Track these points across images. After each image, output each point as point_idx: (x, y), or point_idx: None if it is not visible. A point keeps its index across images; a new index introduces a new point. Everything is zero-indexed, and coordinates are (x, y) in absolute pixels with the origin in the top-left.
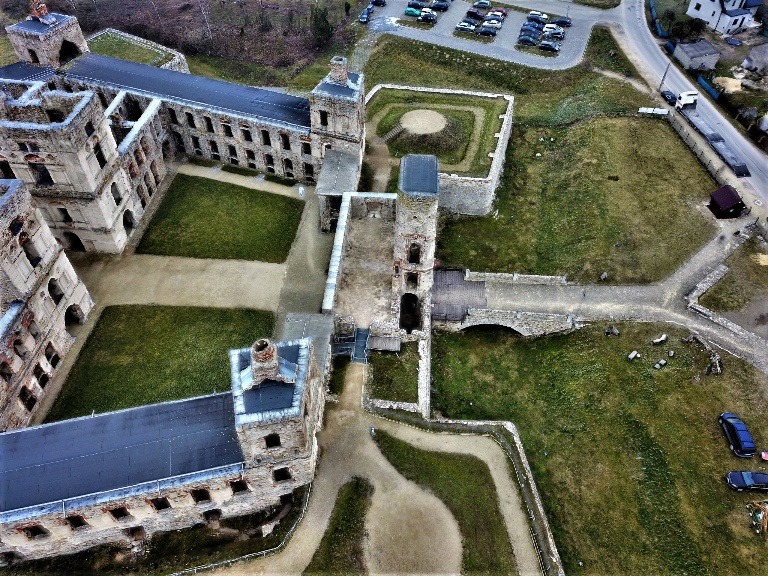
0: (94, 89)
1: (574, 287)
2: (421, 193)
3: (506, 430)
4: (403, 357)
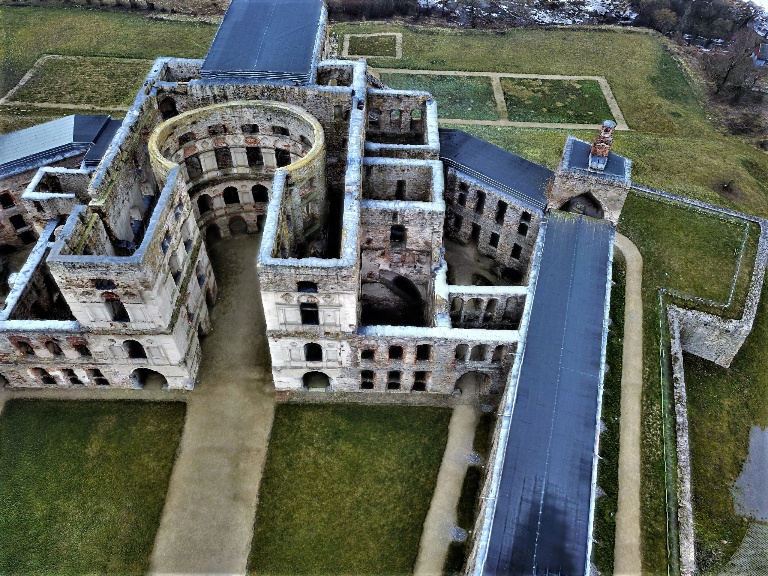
0: None
1: None
2: None
3: None
4: None
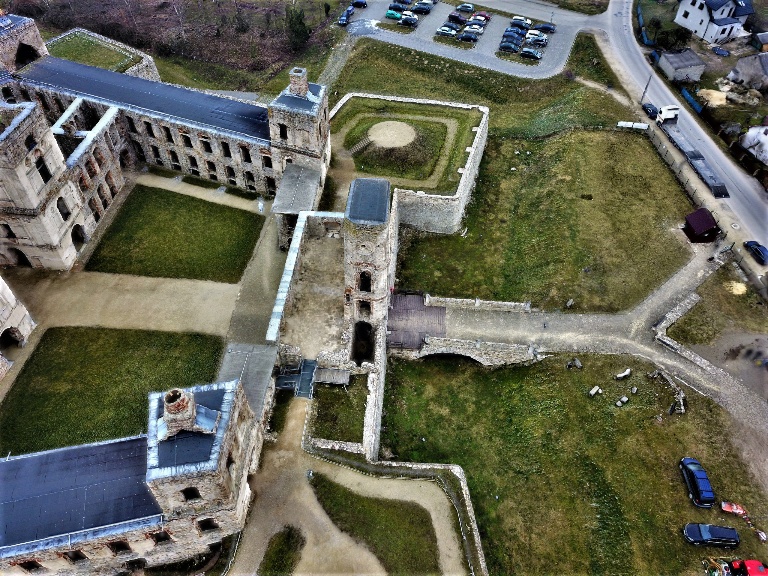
0: (50, 95)
1: (538, 315)
2: (368, 222)
3: (453, 474)
4: (351, 391)
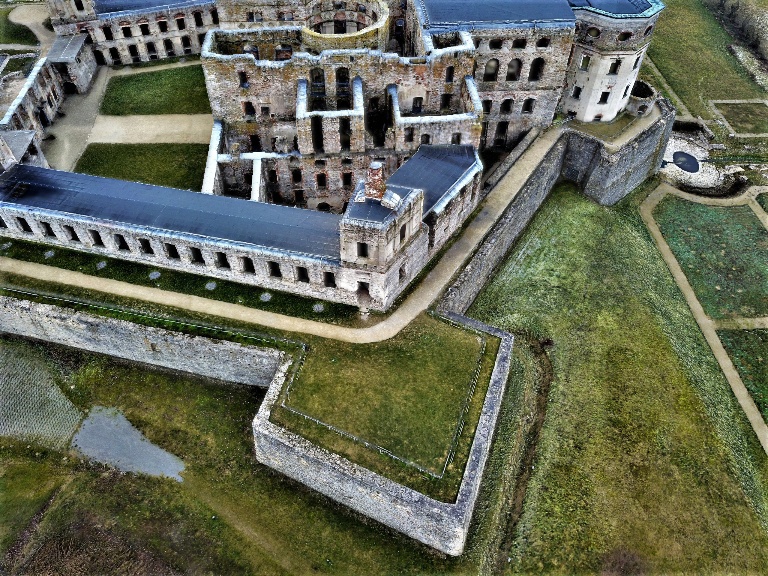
0: None
1: None
2: None
3: None
4: None
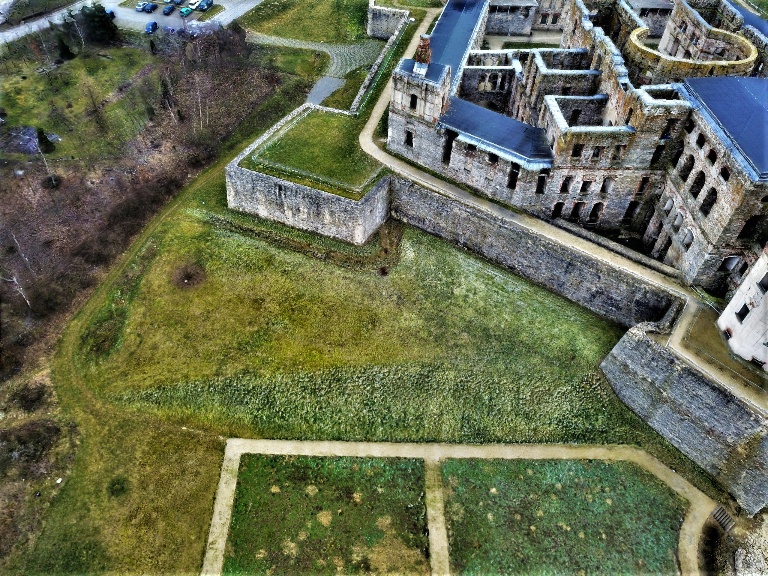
0: None
1: None
2: None
3: None
4: None
